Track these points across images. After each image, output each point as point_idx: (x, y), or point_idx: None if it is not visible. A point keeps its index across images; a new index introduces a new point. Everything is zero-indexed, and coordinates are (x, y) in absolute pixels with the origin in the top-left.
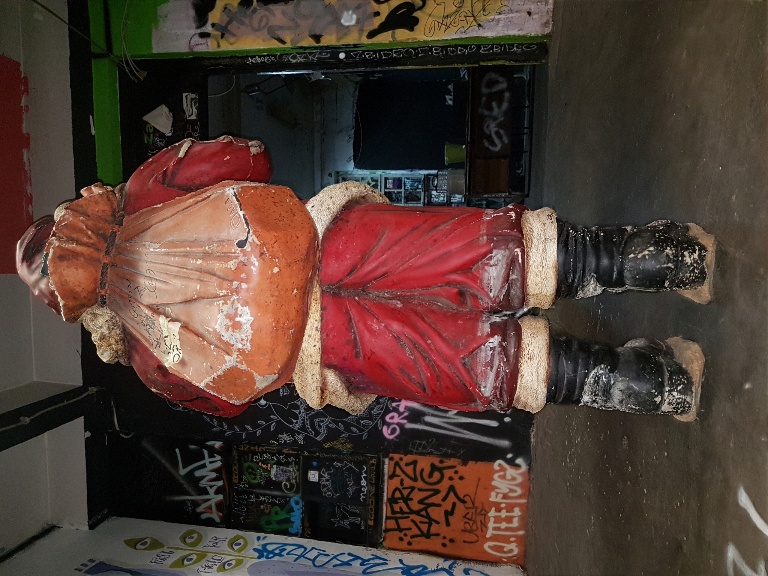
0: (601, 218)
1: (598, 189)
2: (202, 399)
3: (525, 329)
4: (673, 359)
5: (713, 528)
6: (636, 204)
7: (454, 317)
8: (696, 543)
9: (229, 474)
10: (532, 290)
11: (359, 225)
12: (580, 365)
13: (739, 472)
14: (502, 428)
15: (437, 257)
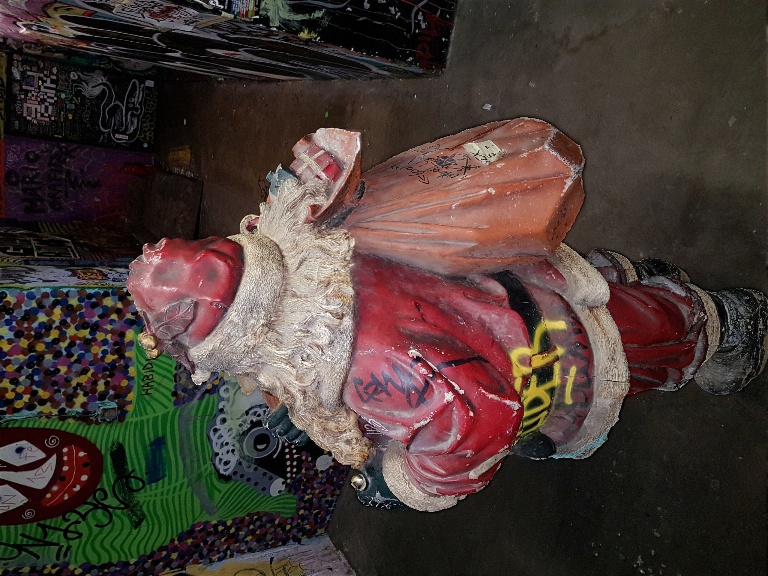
0: (557, 530)
1: (530, 527)
2: (479, 363)
3: None
4: None
5: None
6: None
7: None
8: None
9: None
10: (624, 265)
11: None
12: None
13: None
14: None
15: None
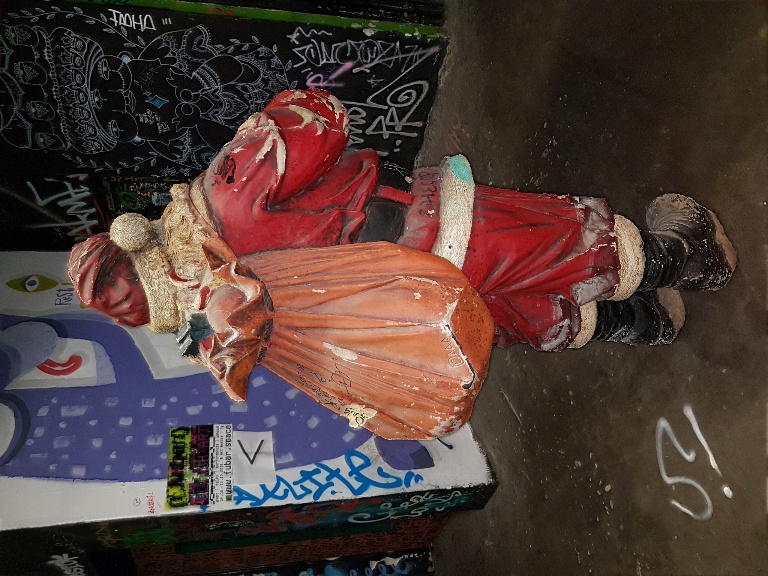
0: (577, 53)
1: (581, 16)
2: None
3: (583, 306)
4: (659, 301)
5: (648, 397)
6: (637, 98)
7: (532, 299)
8: (625, 387)
9: (102, 203)
10: None
11: (486, 255)
12: (612, 327)
13: (691, 399)
14: (391, 157)
15: (548, 281)
